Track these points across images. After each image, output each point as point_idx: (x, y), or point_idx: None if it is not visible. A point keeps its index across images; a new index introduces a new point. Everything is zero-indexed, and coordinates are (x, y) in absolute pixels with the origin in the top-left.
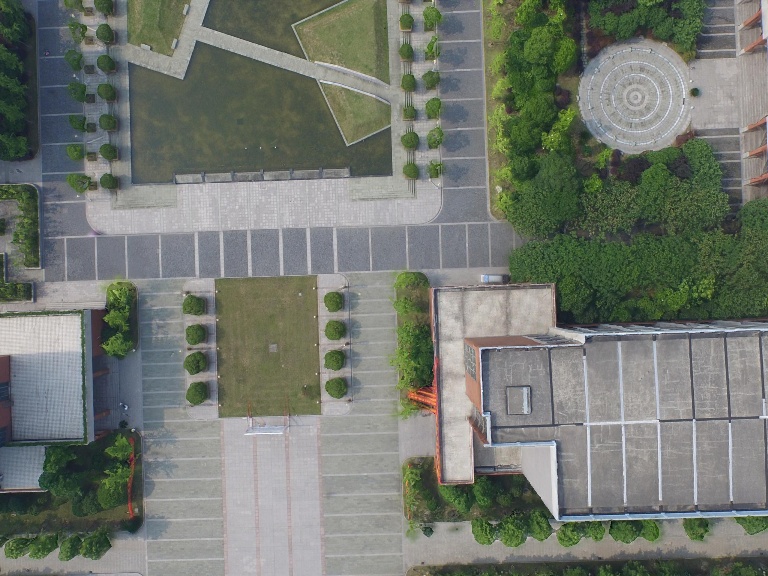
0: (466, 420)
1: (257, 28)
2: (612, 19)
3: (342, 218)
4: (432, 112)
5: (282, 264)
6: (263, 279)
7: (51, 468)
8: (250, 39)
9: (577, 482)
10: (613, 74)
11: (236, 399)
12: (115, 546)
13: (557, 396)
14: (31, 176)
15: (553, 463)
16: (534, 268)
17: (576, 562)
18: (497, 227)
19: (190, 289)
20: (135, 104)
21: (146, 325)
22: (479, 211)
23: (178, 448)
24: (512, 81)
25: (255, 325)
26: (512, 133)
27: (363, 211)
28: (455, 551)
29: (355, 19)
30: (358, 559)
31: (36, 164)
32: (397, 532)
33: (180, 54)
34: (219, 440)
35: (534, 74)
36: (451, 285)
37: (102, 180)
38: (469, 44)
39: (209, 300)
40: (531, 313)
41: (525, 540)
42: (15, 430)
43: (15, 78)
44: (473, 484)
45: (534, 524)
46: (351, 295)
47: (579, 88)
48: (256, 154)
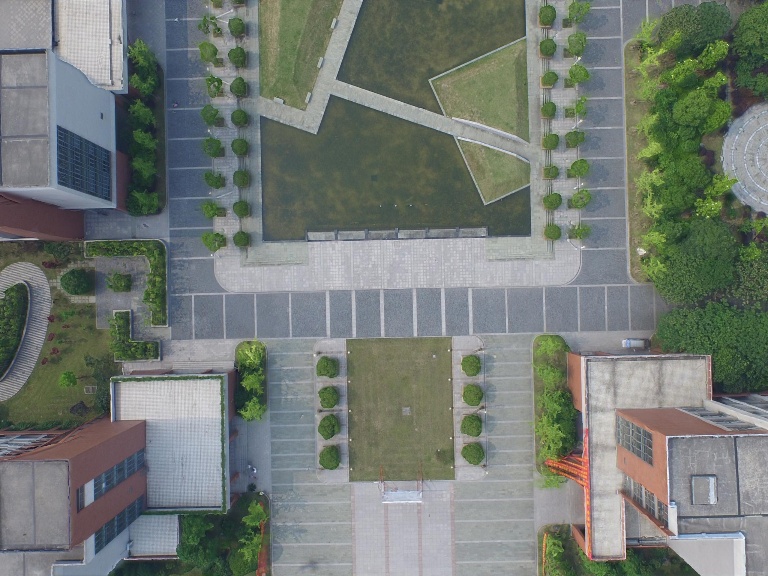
0: (617, 494)
1: (393, 82)
2: (764, 80)
3: (478, 278)
4: (579, 174)
5: (416, 325)
6: (396, 340)
7: (193, 540)
8: (385, 93)
9: (762, 574)
10: (758, 134)
11: (368, 463)
12: None
13: (743, 486)
14: (158, 231)
15: (739, 555)
16: (689, 339)
17: None
18: (637, 290)
19: (321, 349)
20: (266, 159)
21: (275, 385)
22: (619, 273)
23: (307, 512)
24: (658, 141)
25: (388, 387)
26: (662, 197)
27: (500, 271)
28: None
29: (496, 75)
30: None
31: (163, 219)
32: None
33: (314, 108)
34: (349, 504)
35: (681, 135)
36: (589, 349)
37: (237, 239)
38: (610, 101)
39: (340, 361)
40: (684, 384)
41: None
42: (150, 497)
43: (148, 133)
44: None
45: None
46: (486, 357)
47: (723, 148)
48: (390, 212)
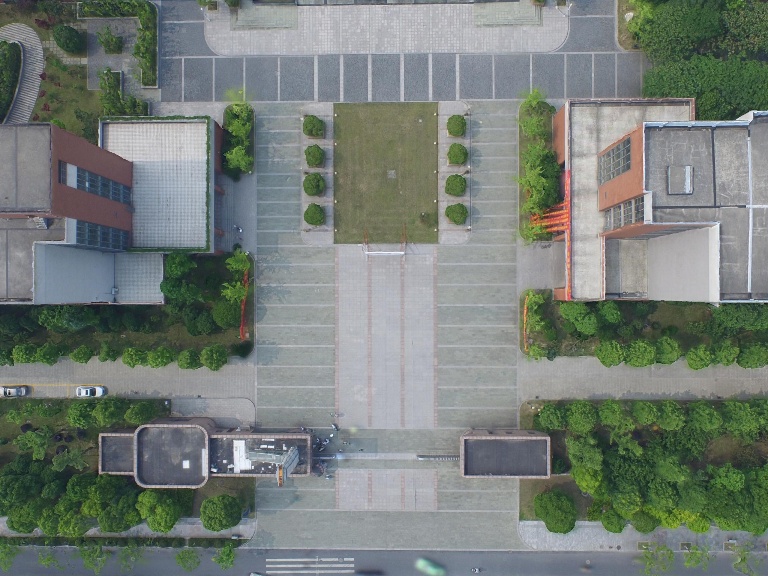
0: (597, 237)
1: None
2: None
3: (466, 44)
4: None
5: (403, 90)
6: (383, 104)
7: (176, 269)
8: None
9: (737, 266)
10: None
11: (352, 225)
12: (224, 371)
13: (719, 177)
14: None
15: (714, 244)
16: (673, 83)
17: (695, 399)
18: (624, 57)
19: (308, 113)
20: None
21: (262, 148)
22: (606, 41)
23: (291, 273)
24: None
25: (374, 150)
26: None
27: (487, 38)
28: (571, 386)
29: None
30: (471, 391)
31: None
32: (512, 365)
33: None
34: (333, 266)
35: None
36: None
37: None
38: None
39: (327, 124)
40: None
41: (654, 361)
42: (135, 238)
43: None
44: (600, 306)
45: (664, 345)
46: (472, 123)
47: None
48: None
